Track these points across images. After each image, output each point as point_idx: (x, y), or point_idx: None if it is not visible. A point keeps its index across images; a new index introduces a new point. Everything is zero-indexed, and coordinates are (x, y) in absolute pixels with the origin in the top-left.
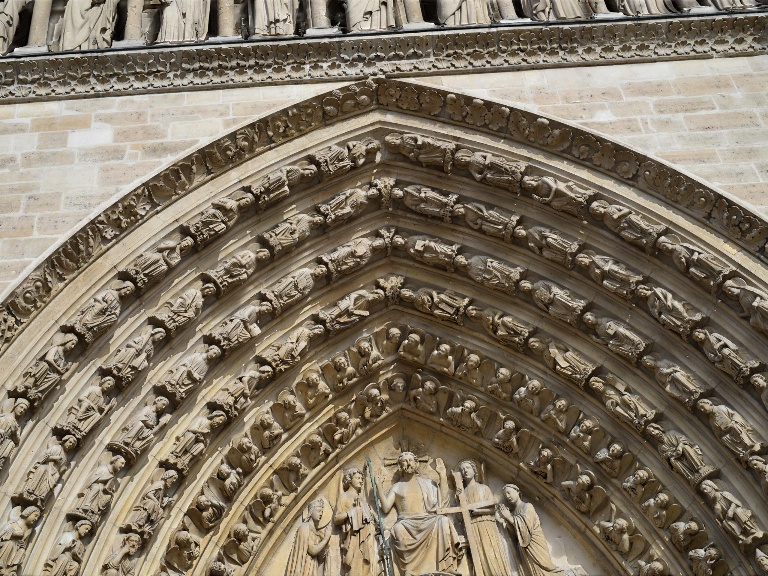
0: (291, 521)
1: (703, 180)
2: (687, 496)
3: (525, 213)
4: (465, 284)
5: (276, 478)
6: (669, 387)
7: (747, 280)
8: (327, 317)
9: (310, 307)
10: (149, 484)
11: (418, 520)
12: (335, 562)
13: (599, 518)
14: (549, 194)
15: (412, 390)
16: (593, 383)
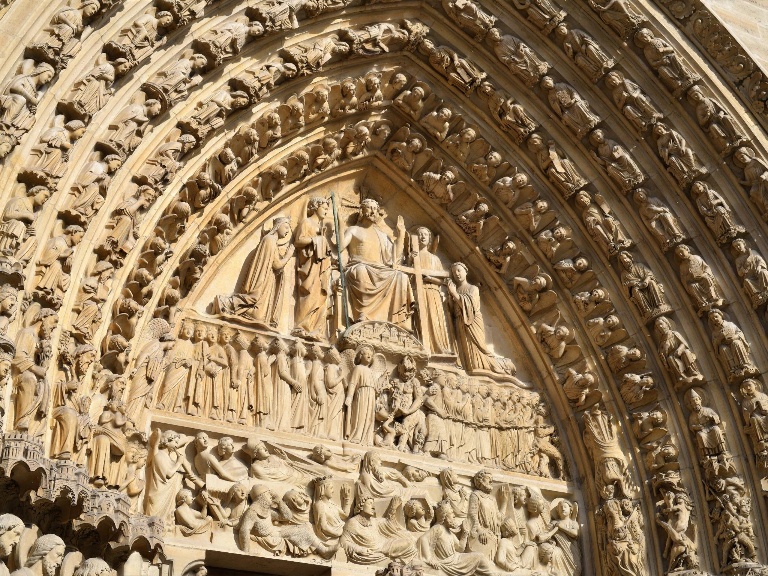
0: (255, 228)
1: (747, 48)
2: (634, 325)
3: (571, 12)
4: (485, 58)
5: (260, 180)
6: (655, 224)
7: (757, 153)
8: (356, 38)
9: (341, 21)
10: (164, 141)
11: (376, 268)
12: (289, 282)
13: (539, 320)
14: (605, 3)
15: (395, 141)
16: (582, 196)
